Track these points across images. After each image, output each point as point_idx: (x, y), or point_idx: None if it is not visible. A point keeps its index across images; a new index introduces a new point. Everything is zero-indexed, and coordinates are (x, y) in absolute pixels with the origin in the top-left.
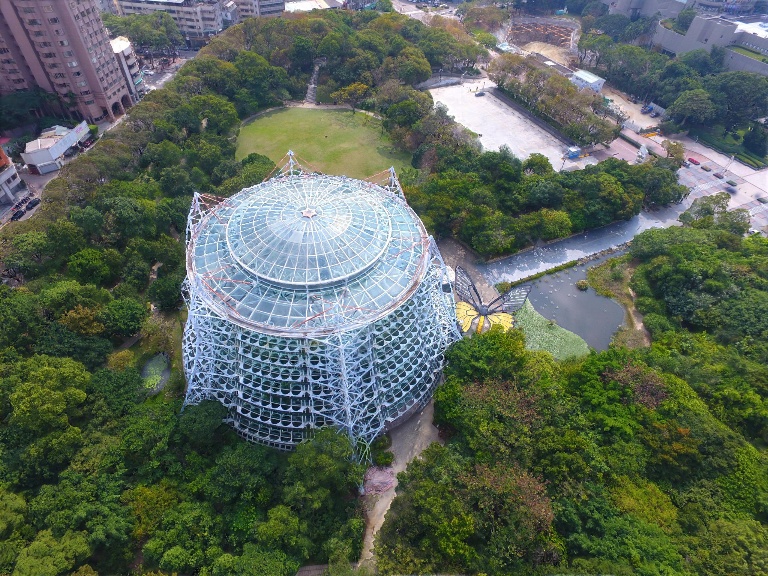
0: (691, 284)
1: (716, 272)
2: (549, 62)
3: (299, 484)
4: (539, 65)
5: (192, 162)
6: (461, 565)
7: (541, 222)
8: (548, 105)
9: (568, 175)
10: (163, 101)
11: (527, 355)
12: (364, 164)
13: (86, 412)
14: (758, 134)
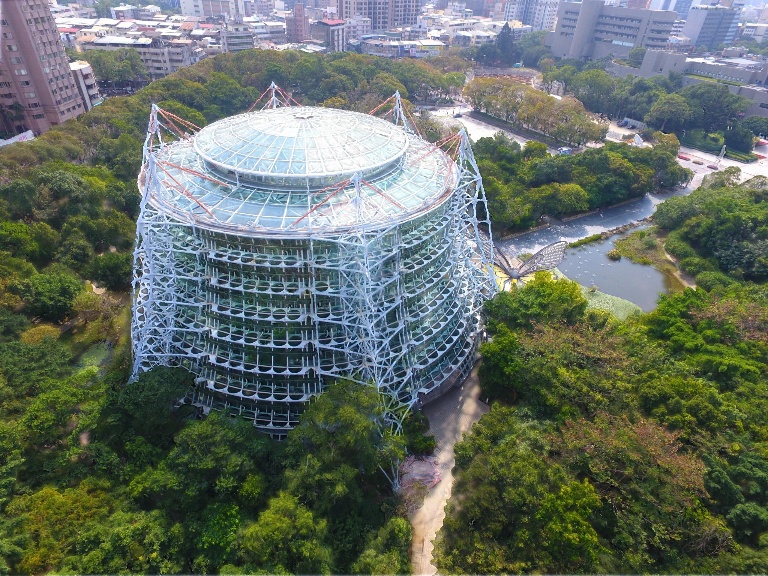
0: (741, 235)
1: (766, 218)
2: None
3: (310, 458)
4: (514, 82)
5: None
6: (582, 570)
7: (556, 192)
8: (530, 113)
9: None
10: (123, 106)
11: None
12: None
13: None
14: (739, 131)
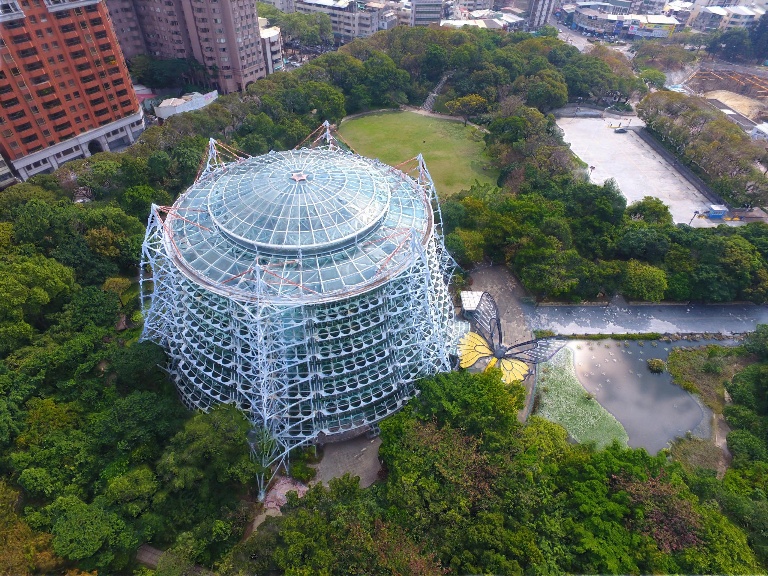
0: None
1: None
2: (728, 110)
3: (172, 455)
4: (703, 106)
5: (279, 137)
6: None
7: (622, 273)
8: (699, 151)
9: (688, 230)
10: (280, 82)
11: (532, 421)
12: (449, 174)
13: (56, 318)
14: None
